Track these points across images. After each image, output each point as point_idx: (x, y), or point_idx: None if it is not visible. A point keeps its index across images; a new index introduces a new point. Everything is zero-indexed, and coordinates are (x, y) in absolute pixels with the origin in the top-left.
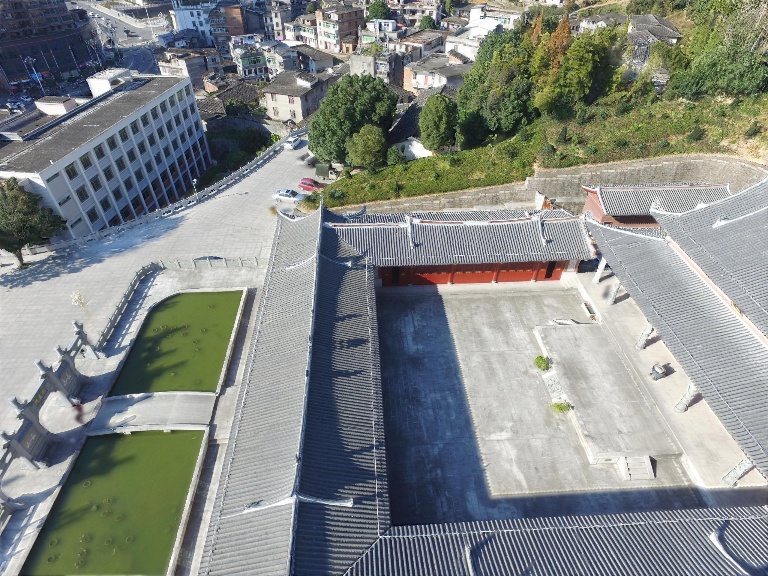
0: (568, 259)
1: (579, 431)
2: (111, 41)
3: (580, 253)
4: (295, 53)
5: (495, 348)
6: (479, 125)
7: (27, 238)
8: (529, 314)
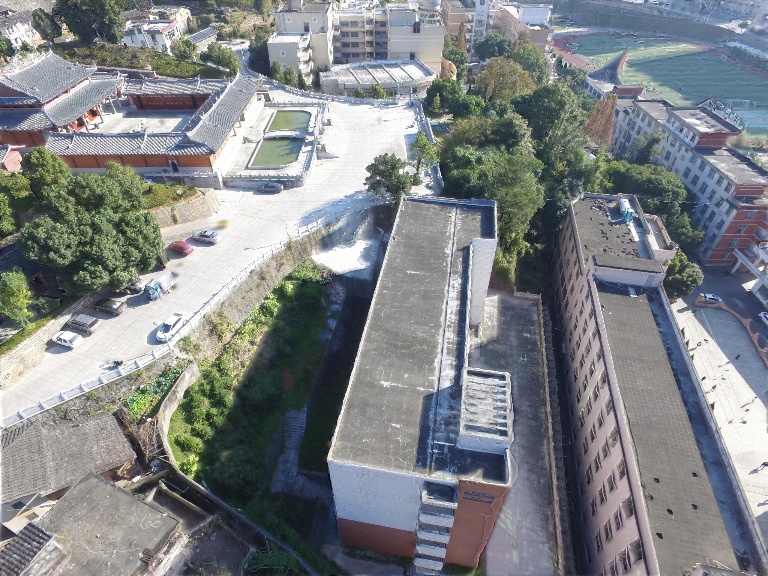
0: None
1: None
2: None
3: None
4: None
5: None
6: None
7: None
8: None
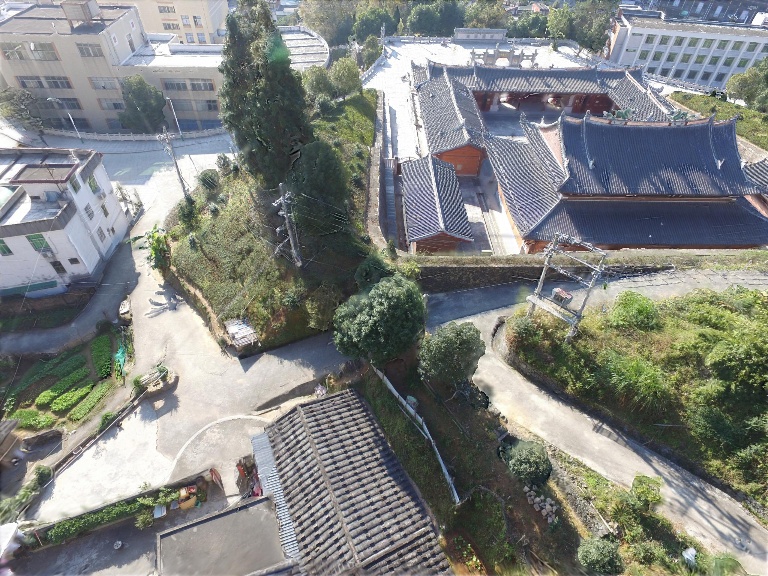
0: None
1: None
2: None
3: None
4: None
5: None
6: None
7: (587, 42)
8: None
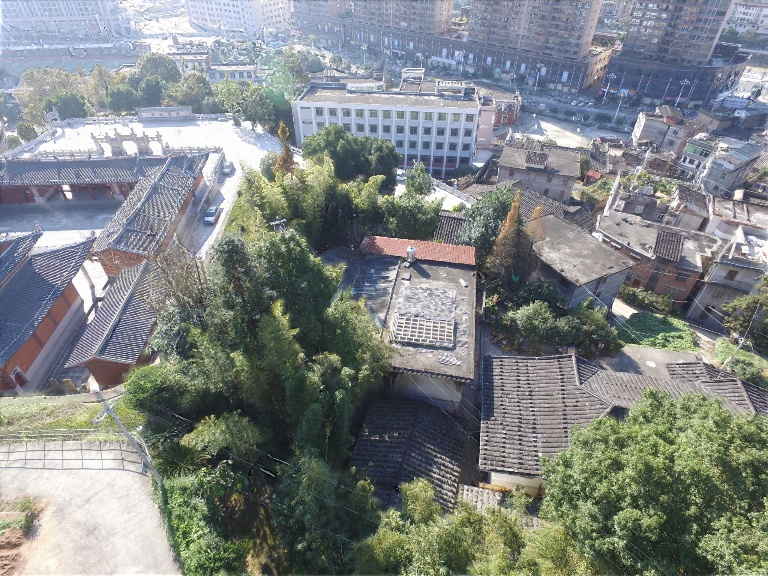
0: None
1: None
2: (755, 93)
3: None
4: (733, 166)
5: None
6: None
7: None
8: None
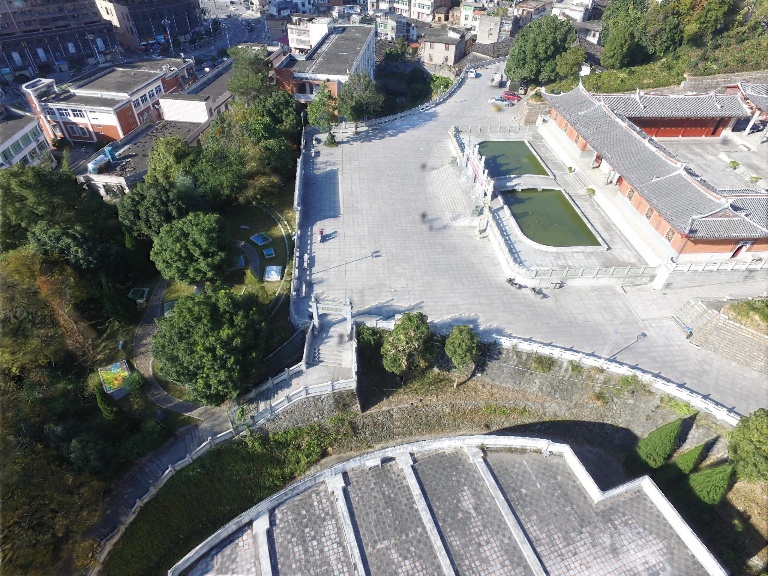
0: (735, 116)
1: (767, 187)
2: None
3: (741, 113)
4: (405, 19)
5: (700, 162)
6: (640, 51)
7: (368, 111)
8: (710, 150)
